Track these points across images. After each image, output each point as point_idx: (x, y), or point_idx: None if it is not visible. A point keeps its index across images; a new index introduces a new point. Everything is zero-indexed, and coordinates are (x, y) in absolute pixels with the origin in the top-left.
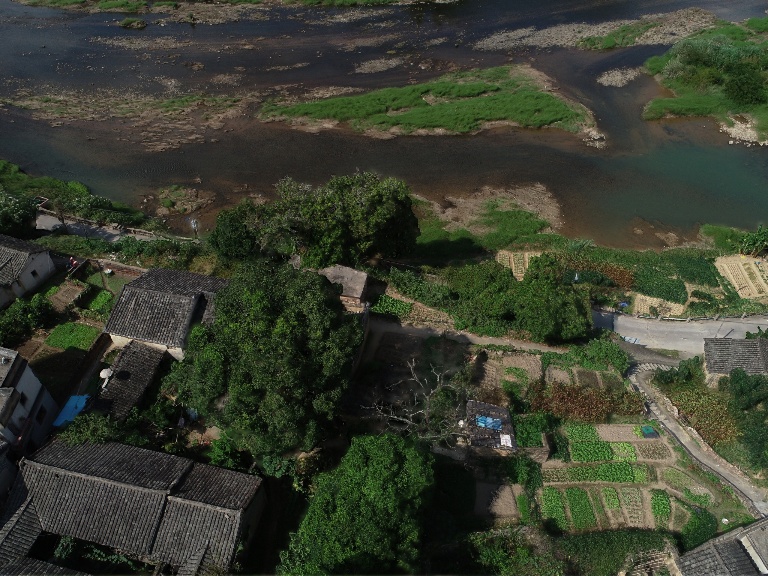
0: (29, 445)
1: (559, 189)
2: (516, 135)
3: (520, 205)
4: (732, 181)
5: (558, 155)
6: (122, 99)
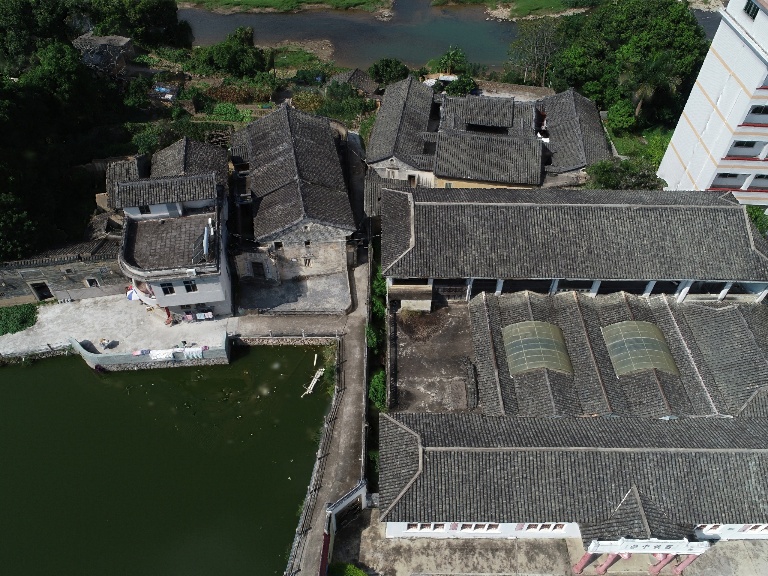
0: None
1: (340, 42)
2: (327, 13)
3: (305, 50)
4: (473, 40)
5: (351, 24)
6: None
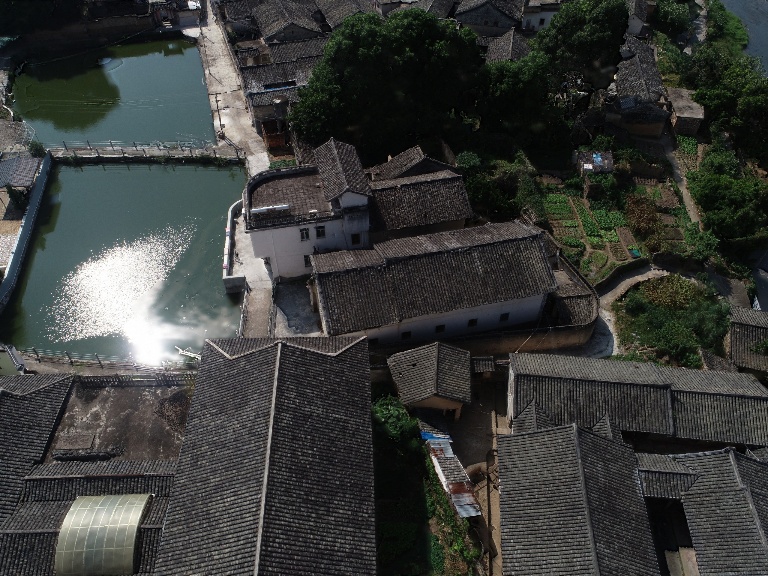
0: None
1: None
2: None
3: None
4: None
5: None
6: None
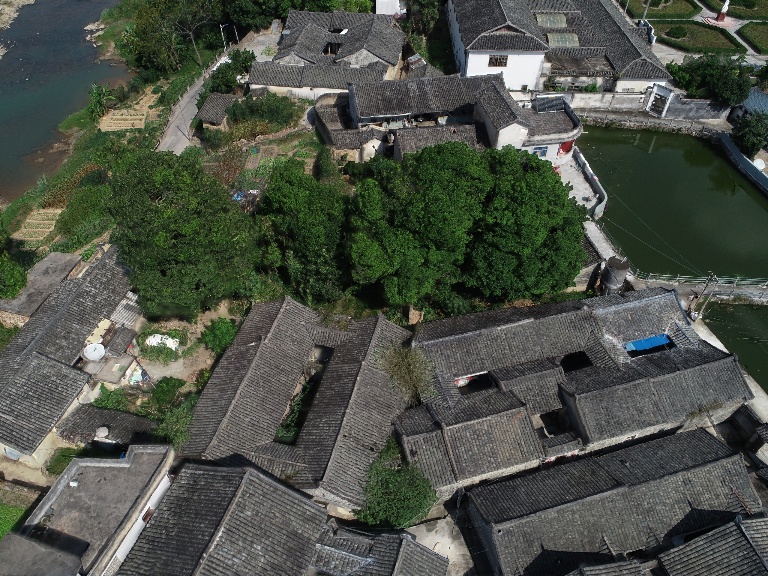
0: None
1: None
2: None
3: None
4: (15, 104)
5: None
6: None
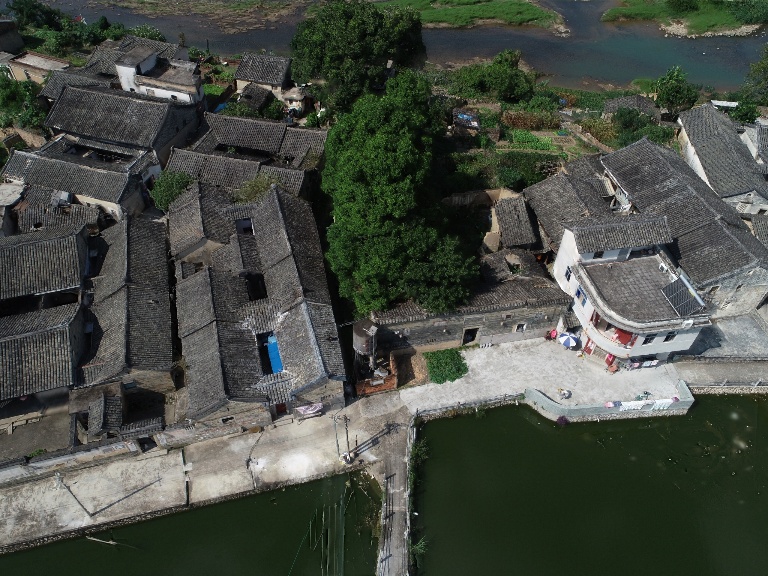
0: (200, 122)
1: (531, 59)
2: (502, 29)
3: None
4: (662, 58)
5: (533, 40)
6: (199, 3)
